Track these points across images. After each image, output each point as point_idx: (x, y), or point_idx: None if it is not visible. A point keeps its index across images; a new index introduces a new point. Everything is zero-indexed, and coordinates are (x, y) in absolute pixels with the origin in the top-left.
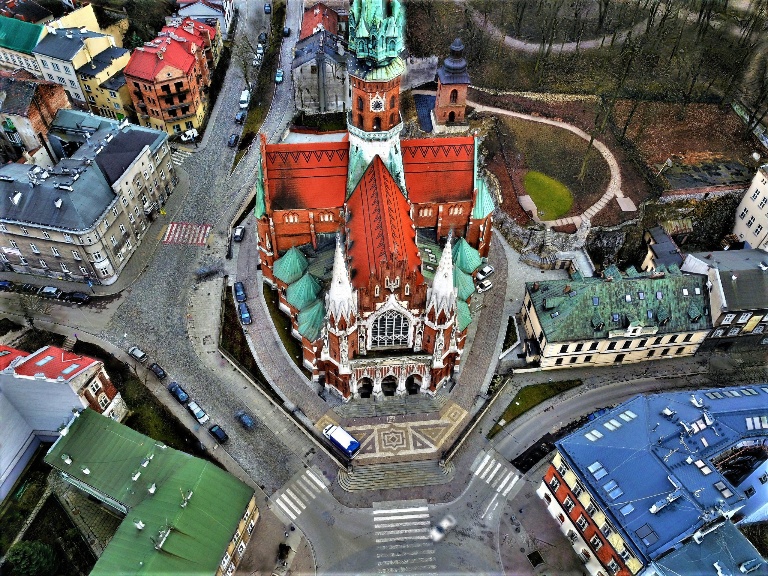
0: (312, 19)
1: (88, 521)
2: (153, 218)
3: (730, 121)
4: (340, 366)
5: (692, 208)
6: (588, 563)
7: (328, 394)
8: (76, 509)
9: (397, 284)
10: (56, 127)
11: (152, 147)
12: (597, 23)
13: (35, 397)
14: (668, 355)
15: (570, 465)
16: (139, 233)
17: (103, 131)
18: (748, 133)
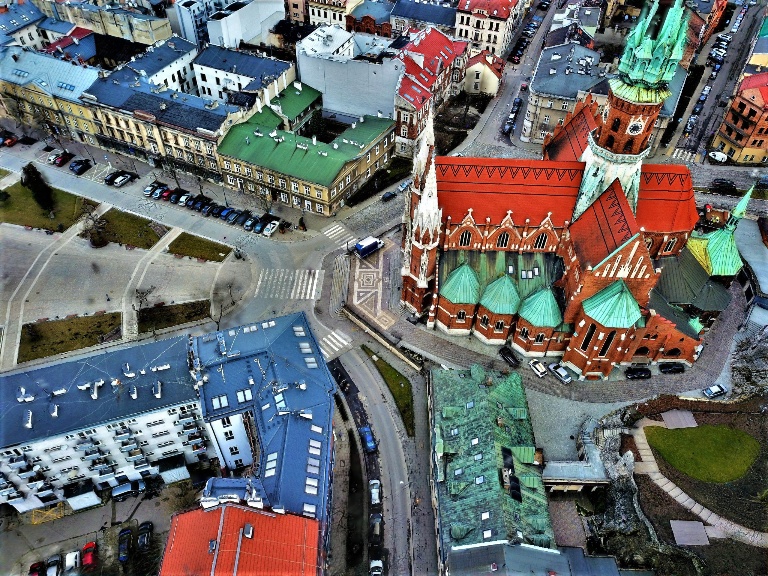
0: None
1: None
2: None
3: None
4: None
5: None
6: None
7: None
8: None
9: None
10: None
11: None
12: None
13: None
14: None
15: None
16: None
17: None
18: None
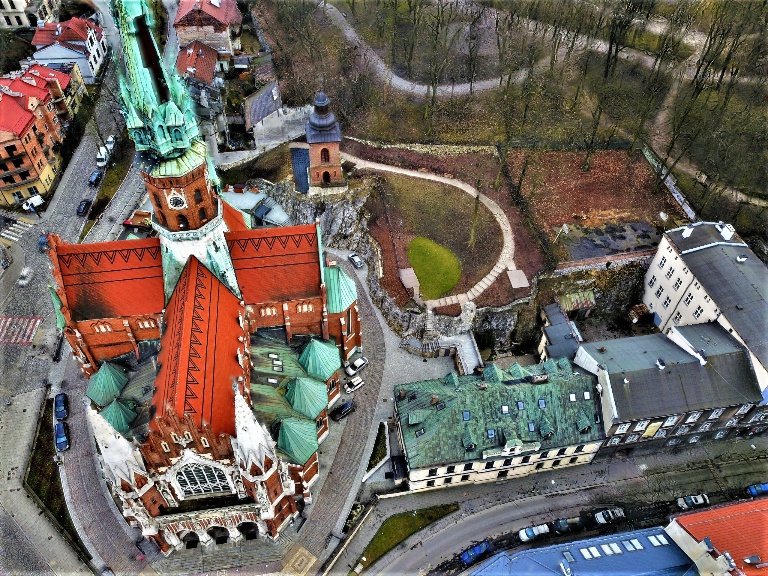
0: (185, 60)
1: None
2: None
3: (640, 170)
4: None
5: (593, 279)
6: None
7: (148, 543)
8: None
9: (189, 438)
10: None
11: None
12: None
13: None
14: (561, 465)
15: None
16: None
17: None
18: (657, 186)
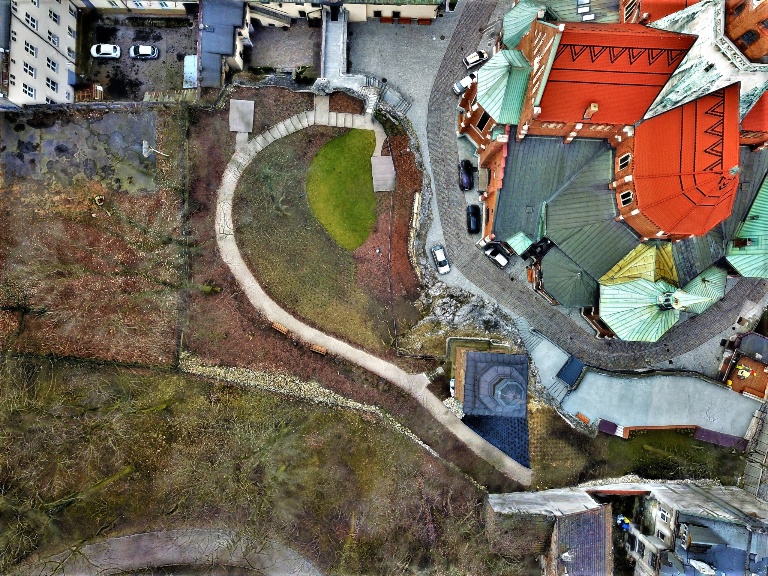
0: None
1: None
2: None
3: None
4: None
5: None
6: None
7: None
8: None
9: None
10: None
11: None
12: None
13: None
14: None
15: None
16: None
17: None
18: None
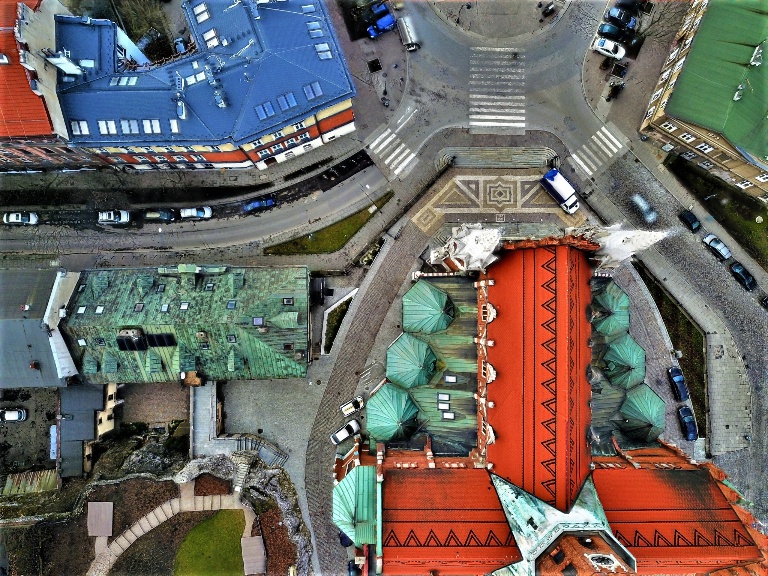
0: None
1: None
2: None
3: None
4: None
5: None
6: None
7: None
8: None
9: None
10: None
11: None
12: None
13: None
14: None
15: None
16: None
17: None
18: None
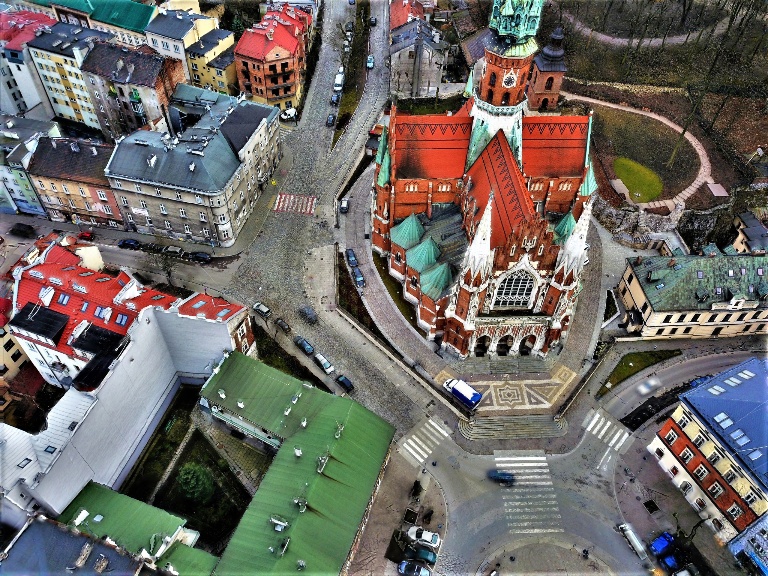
0: (401, 9)
1: (232, 455)
2: (263, 188)
3: None
4: (466, 323)
5: None
6: (702, 512)
7: (444, 352)
8: (220, 444)
9: (533, 244)
10: (176, 99)
11: (267, 121)
12: (678, 21)
13: (190, 337)
14: (762, 331)
15: (695, 416)
16: (252, 201)
17: (221, 104)
18: None
